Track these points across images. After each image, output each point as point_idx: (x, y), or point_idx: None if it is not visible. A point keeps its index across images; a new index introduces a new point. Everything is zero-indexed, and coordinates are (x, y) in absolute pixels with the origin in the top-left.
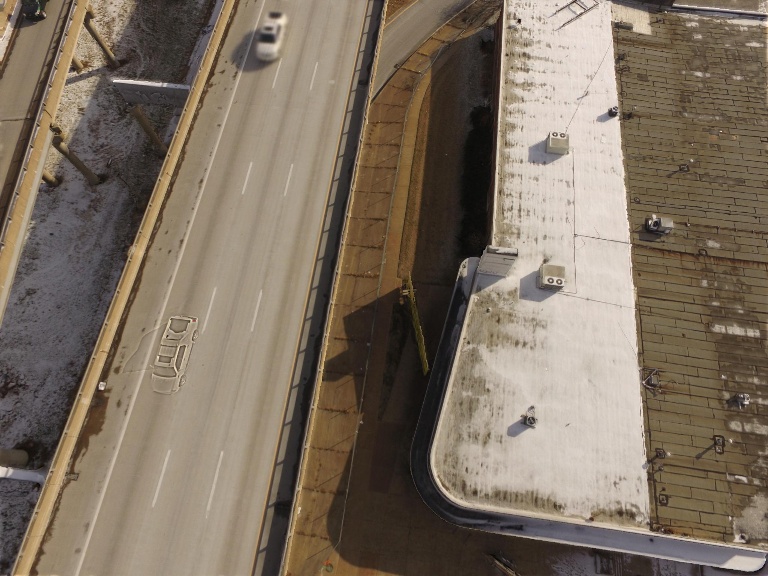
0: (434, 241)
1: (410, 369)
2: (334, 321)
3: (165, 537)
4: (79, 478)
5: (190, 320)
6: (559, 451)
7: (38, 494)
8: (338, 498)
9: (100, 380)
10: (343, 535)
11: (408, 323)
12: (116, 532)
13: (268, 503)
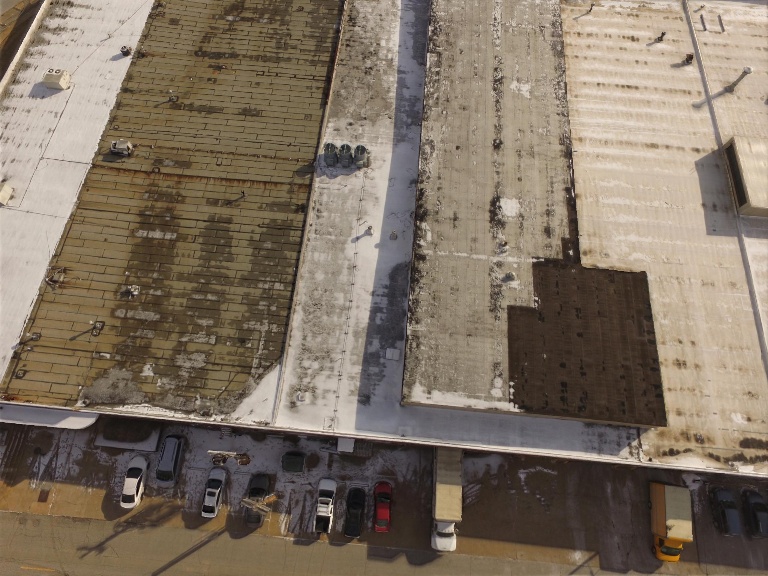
0: None
1: None
2: None
3: None
4: None
5: None
6: None
7: None
8: None
9: None
10: None
11: None
12: None
13: None
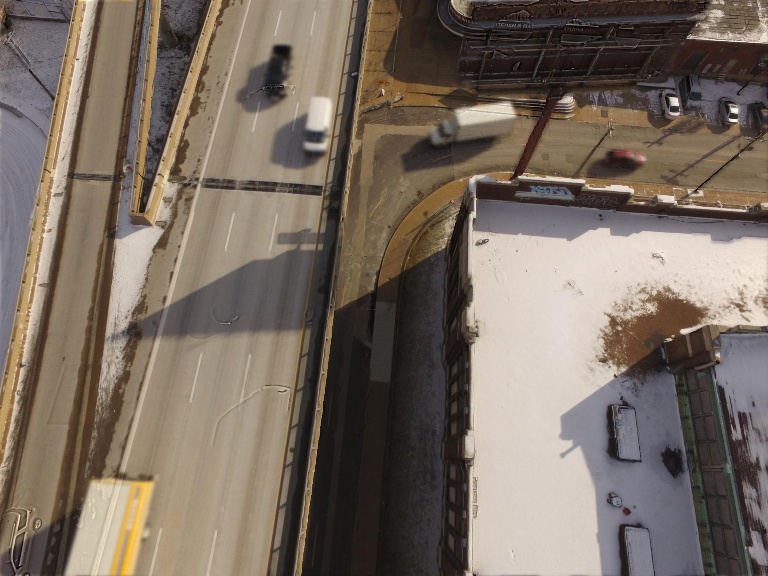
0: None
1: None
2: None
3: None
4: None
5: None
6: None
7: (188, 58)
8: (390, 53)
9: None
10: (395, 69)
11: None
12: None
13: None
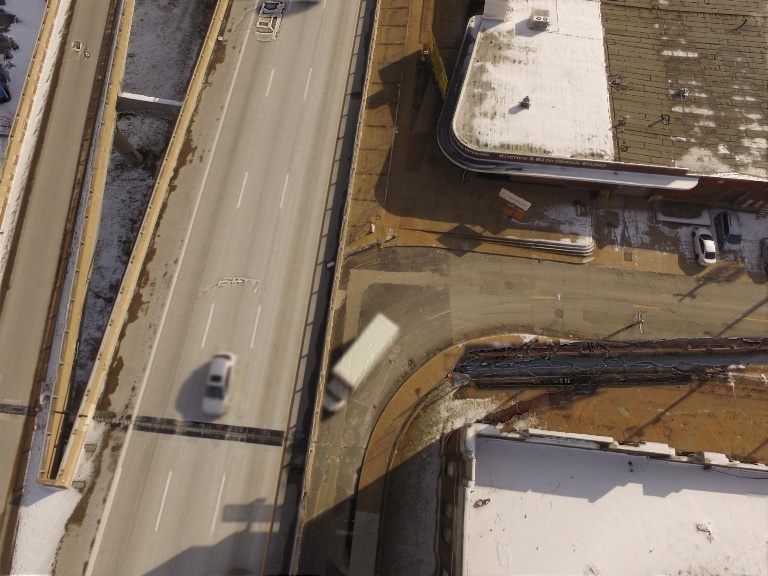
0: (447, 20)
1: (432, 100)
2: None
3: (277, 111)
4: (212, 85)
5: (279, 3)
6: (547, 122)
7: None
8: (382, 177)
9: (218, 36)
10: (387, 198)
11: (429, 72)
12: (243, 110)
13: (346, 93)
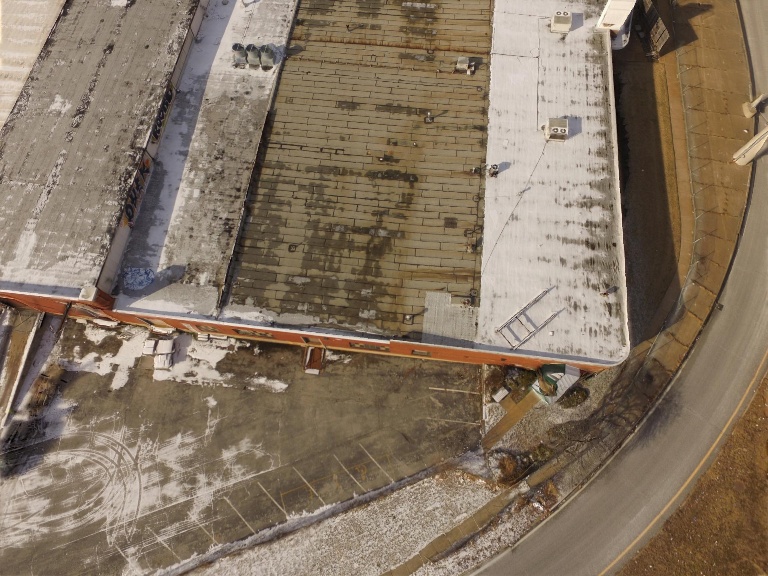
0: (640, 90)
1: None
2: (705, 37)
3: None
4: None
5: None
6: None
7: None
8: None
9: None
10: None
11: None
12: None
13: None
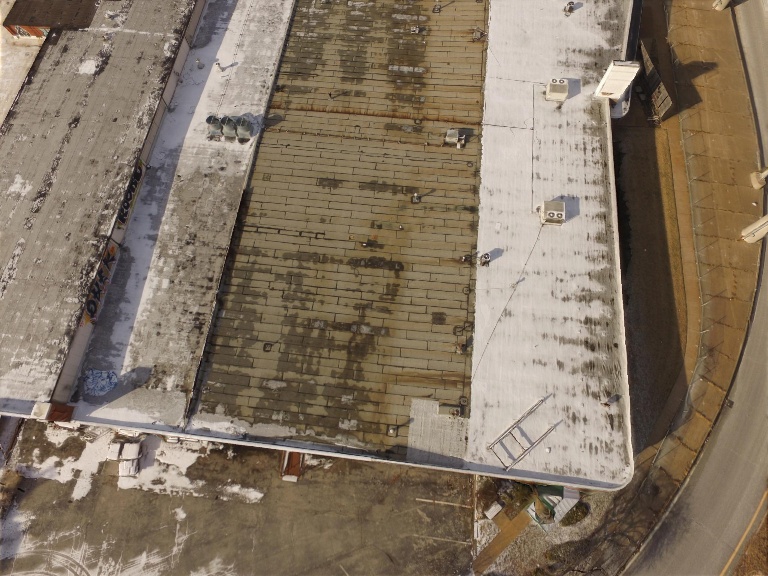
0: (641, 159)
1: None
2: (709, 99)
3: None
4: None
5: None
6: None
7: None
8: (669, 4)
9: None
10: None
11: None
12: None
13: None
